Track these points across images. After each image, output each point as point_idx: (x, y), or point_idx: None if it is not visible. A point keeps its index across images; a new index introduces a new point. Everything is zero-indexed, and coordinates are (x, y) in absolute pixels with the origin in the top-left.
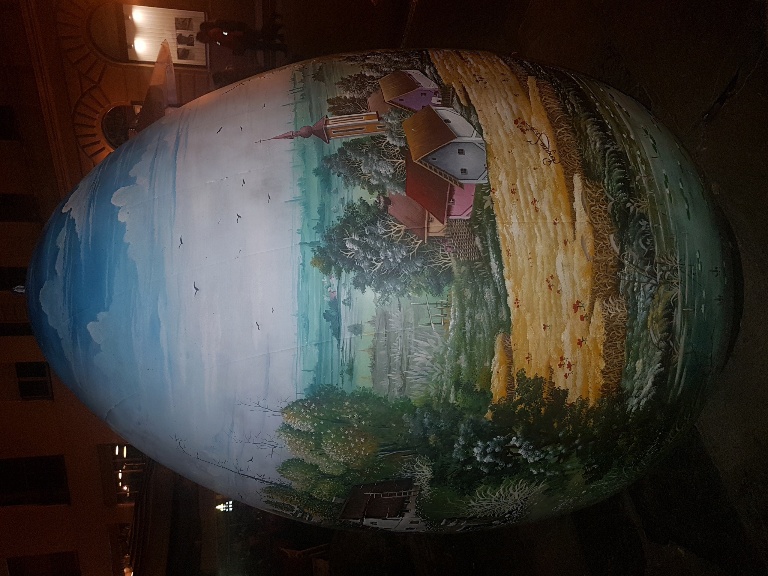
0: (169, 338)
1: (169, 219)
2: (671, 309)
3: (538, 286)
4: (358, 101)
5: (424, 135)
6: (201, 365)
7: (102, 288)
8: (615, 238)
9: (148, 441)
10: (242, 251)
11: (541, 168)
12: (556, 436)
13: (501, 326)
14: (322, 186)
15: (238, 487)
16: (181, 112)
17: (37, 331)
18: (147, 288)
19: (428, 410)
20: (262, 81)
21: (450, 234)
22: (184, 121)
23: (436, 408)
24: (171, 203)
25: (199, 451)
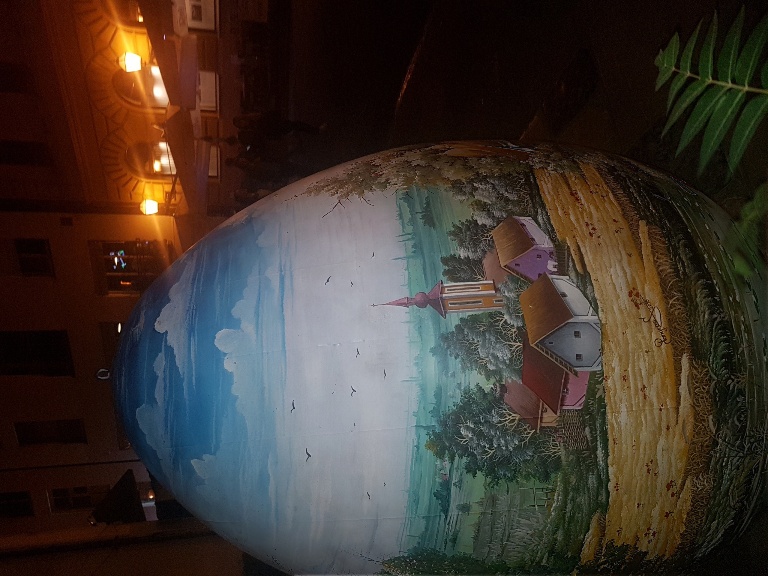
0: (278, 491)
1: (280, 380)
2: (752, 475)
3: (638, 471)
4: (473, 264)
5: (541, 313)
6: (308, 518)
7: (209, 433)
8: (713, 418)
9: (241, 547)
10: (356, 426)
11: (653, 350)
12: None
13: (599, 507)
14: (439, 368)
15: None
16: (277, 233)
17: (129, 435)
18: (257, 444)
19: (520, 570)
20: (364, 207)
21: (562, 424)
22: (285, 253)
23: (528, 569)
24: (282, 363)
25: (294, 569)
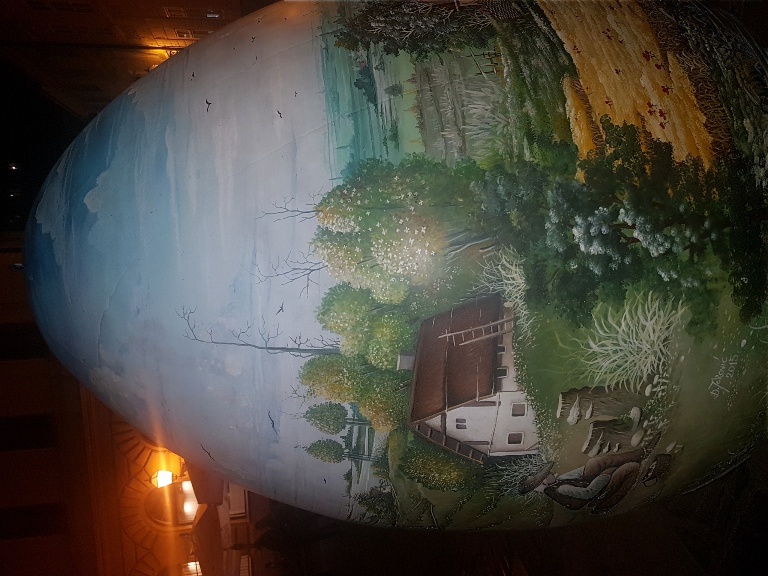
0: (177, 163)
1: (181, 67)
2: (759, 75)
3: (595, 36)
4: None
5: None
6: (214, 181)
7: (105, 150)
8: (665, 10)
9: (149, 347)
10: (259, 58)
11: None
12: (676, 211)
13: (565, 70)
14: None
15: (267, 390)
16: None
17: (28, 267)
18: (154, 125)
19: (500, 174)
20: None
21: (483, 3)
22: None
23: (510, 170)
24: (184, 59)
25: (213, 324)
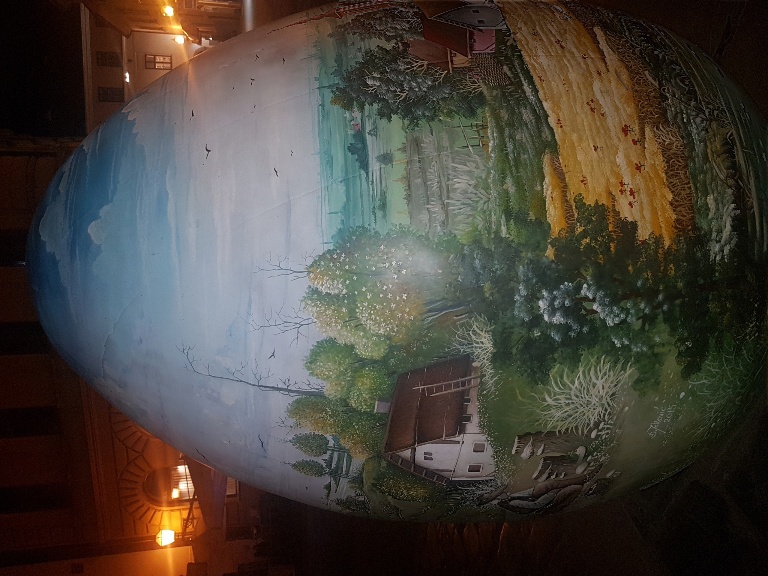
0: (178, 210)
1: (180, 101)
2: (730, 146)
3: (579, 108)
4: None
5: (436, 5)
6: (213, 232)
7: (107, 181)
8: (650, 74)
9: (150, 372)
10: (257, 106)
11: (559, 21)
12: (634, 286)
13: (546, 146)
14: (337, 43)
15: (258, 418)
16: None
17: (33, 277)
18: (155, 165)
19: (478, 248)
20: None
21: (476, 65)
22: None
23: (487, 245)
24: (183, 89)
25: (211, 360)
